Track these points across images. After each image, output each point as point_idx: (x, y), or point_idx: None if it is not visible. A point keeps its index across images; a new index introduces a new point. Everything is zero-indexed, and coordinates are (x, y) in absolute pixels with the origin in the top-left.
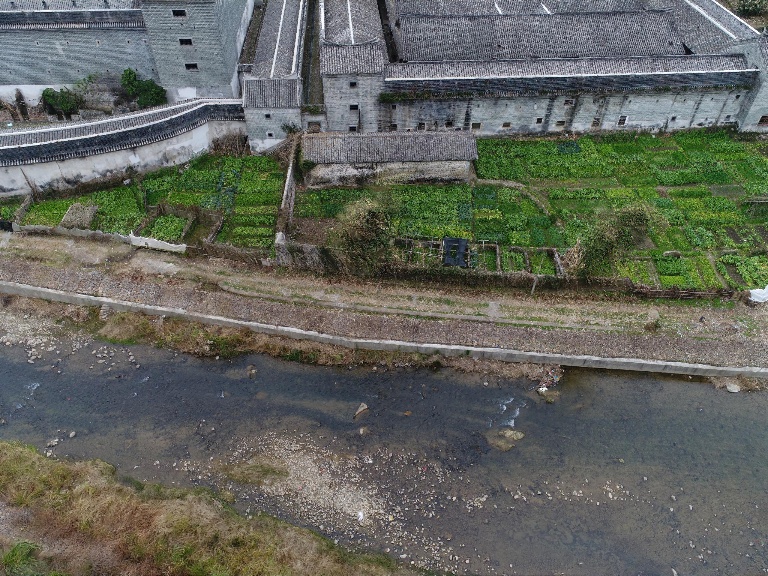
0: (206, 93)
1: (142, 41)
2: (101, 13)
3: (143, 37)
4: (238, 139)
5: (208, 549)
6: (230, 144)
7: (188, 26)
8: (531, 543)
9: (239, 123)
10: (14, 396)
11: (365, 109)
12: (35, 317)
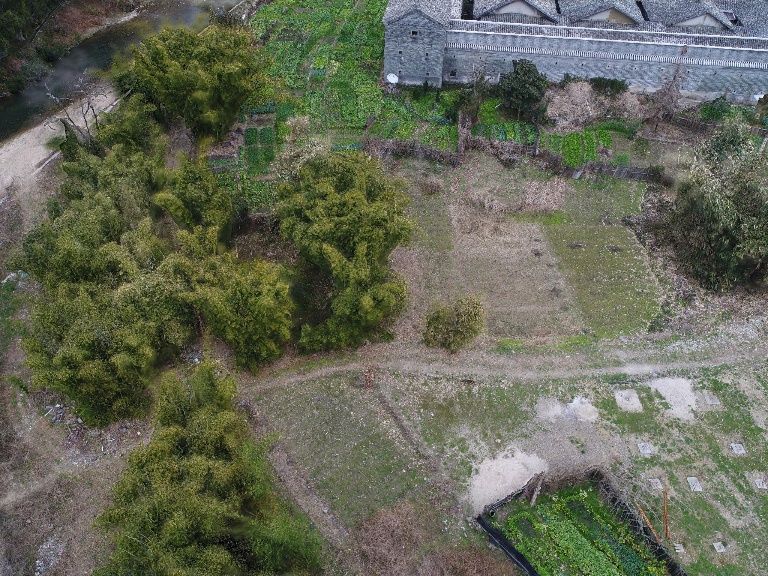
0: None
1: None
2: None
3: None
4: None
5: None
6: None
7: None
8: None
9: None
10: None
11: None
12: None
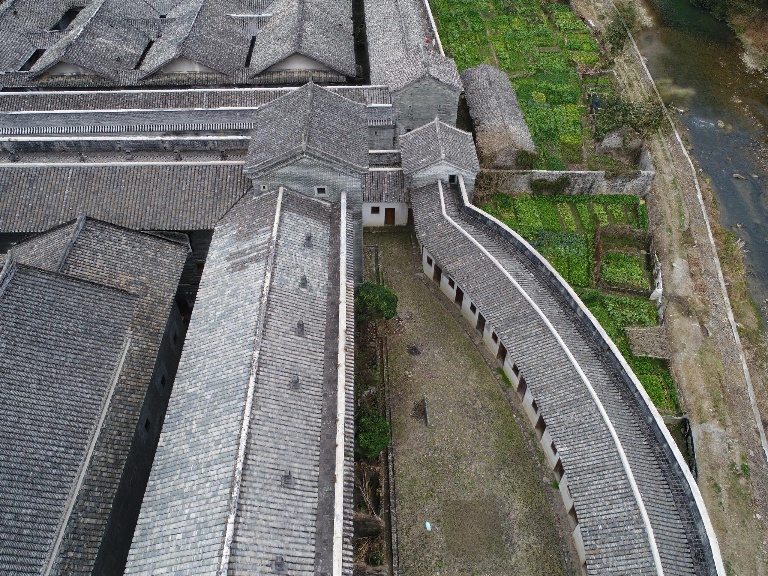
0: None
1: None
2: None
3: None
4: None
5: None
6: None
7: None
8: None
9: None
10: None
11: None
12: (766, 391)
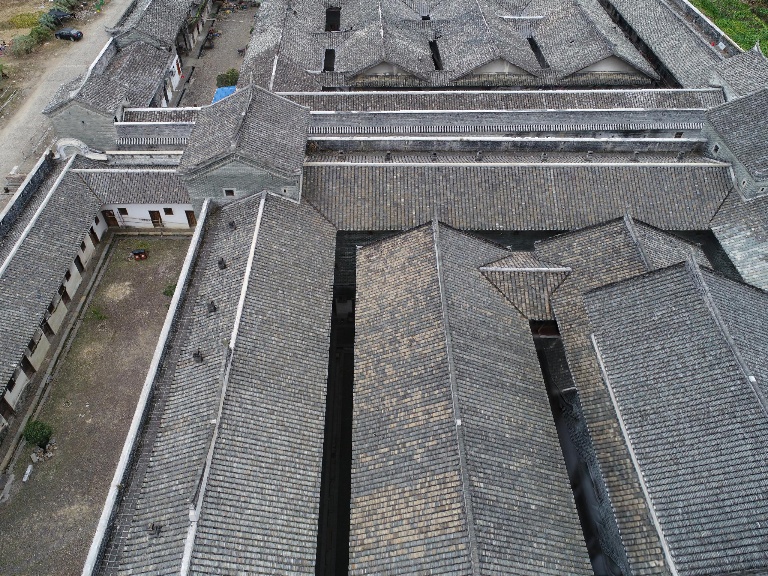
0: None
1: None
2: None
3: None
4: None
5: None
6: None
7: None
8: None
9: None
10: None
11: None
12: None
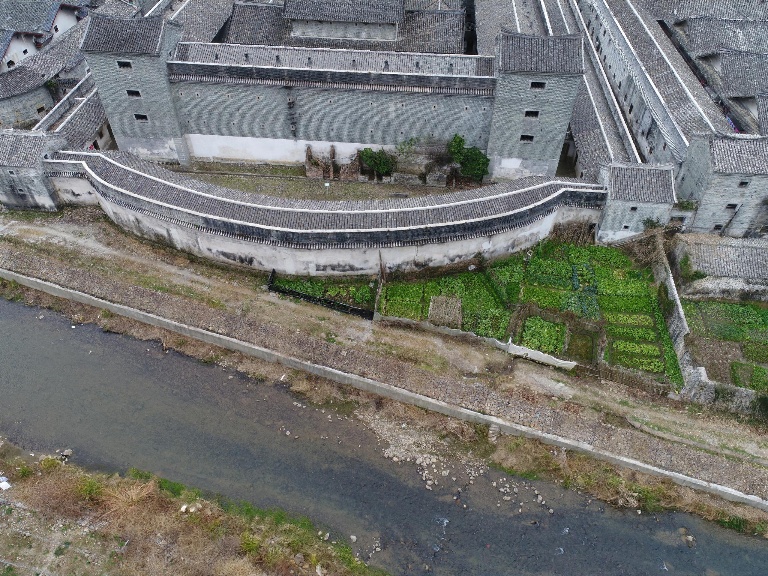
0: (530, 165)
1: (481, 109)
2: (450, 79)
3: (484, 105)
4: (585, 227)
5: None
6: (573, 231)
7: (541, 98)
8: None
9: (591, 211)
10: (425, 532)
11: (743, 209)
12: (413, 428)
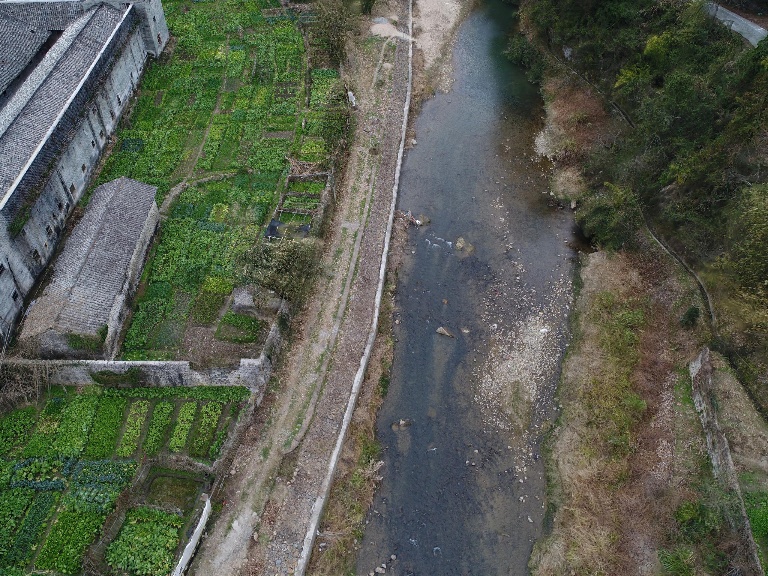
0: None
1: None
2: None
3: None
4: None
5: (600, 428)
6: None
7: None
8: (541, 246)
9: None
10: None
11: (8, 261)
12: None
